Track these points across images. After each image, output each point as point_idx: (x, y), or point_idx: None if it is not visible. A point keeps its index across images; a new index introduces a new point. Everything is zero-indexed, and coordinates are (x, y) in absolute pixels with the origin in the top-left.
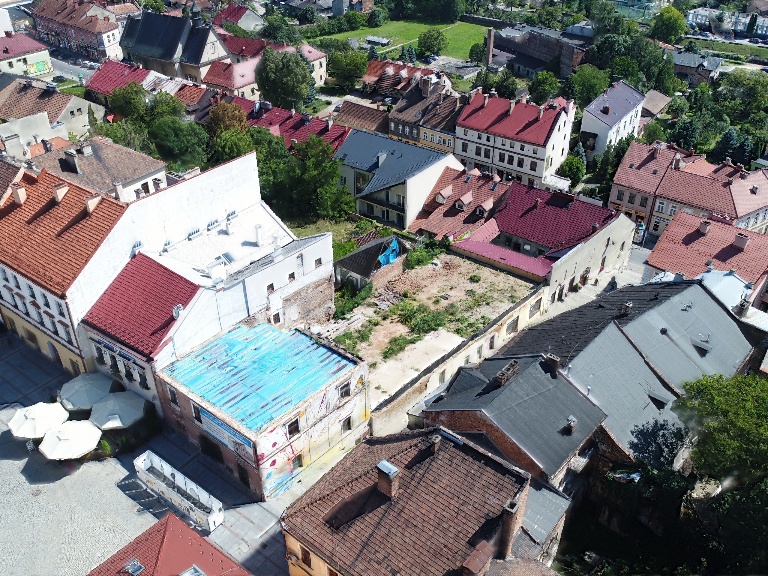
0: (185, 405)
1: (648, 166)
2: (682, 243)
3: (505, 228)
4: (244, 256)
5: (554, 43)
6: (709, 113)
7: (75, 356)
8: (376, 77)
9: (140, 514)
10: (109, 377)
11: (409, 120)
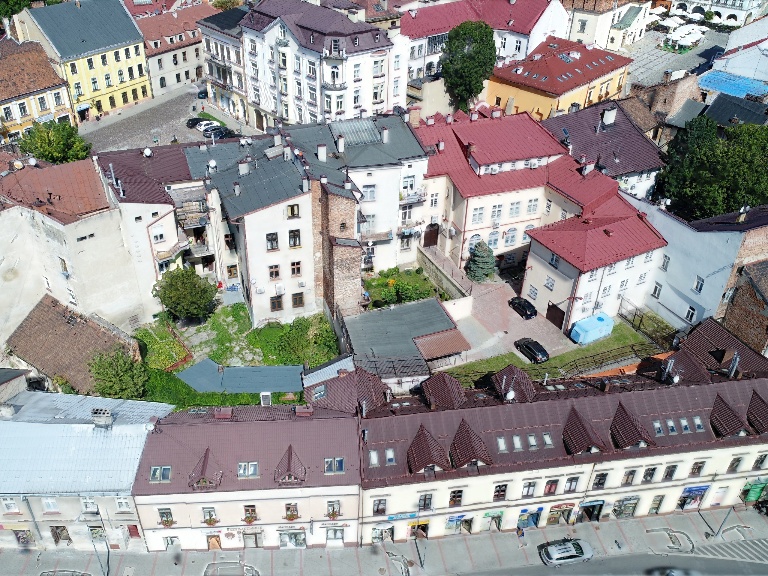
0: None
1: None
2: None
3: None
4: None
5: None
6: None
7: None
8: None
9: None
10: None
11: None
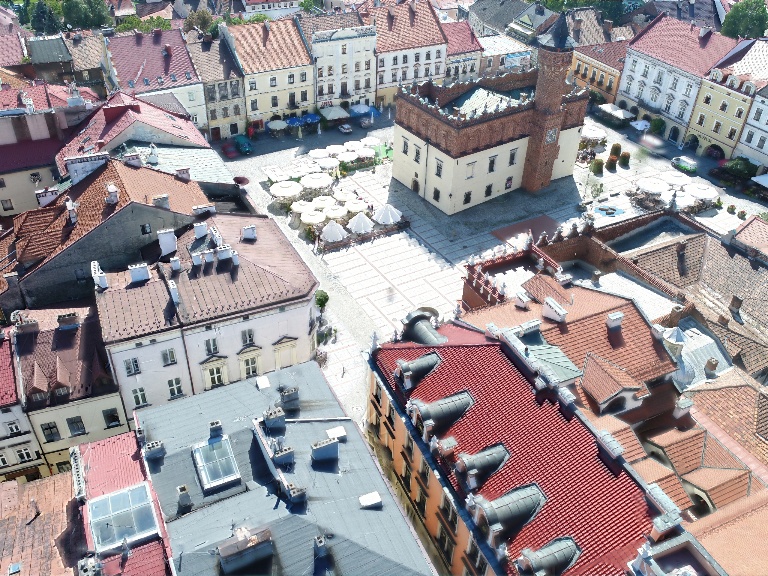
0: None
1: None
2: None
3: None
4: None
5: None
6: None
7: None
8: None
9: None
10: None
11: None
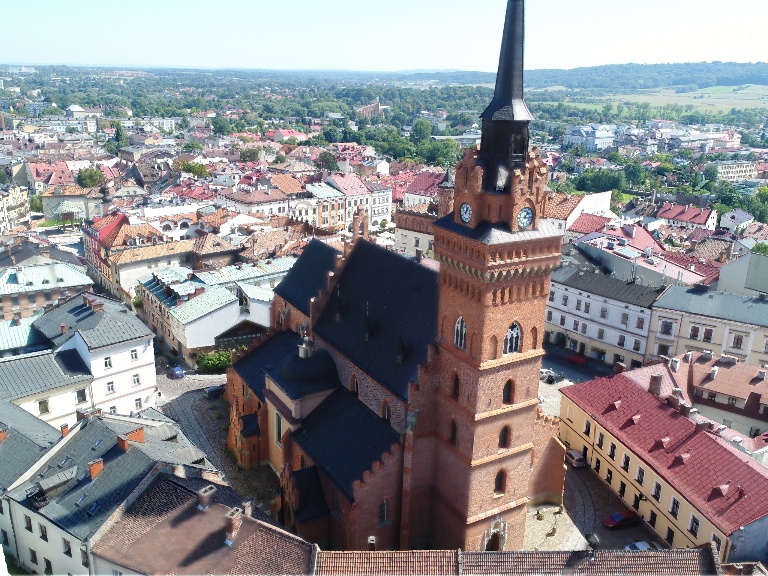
0: None
1: (759, 233)
2: None
3: None
4: None
5: (694, 199)
6: None
7: None
8: None
9: None
10: None
11: None
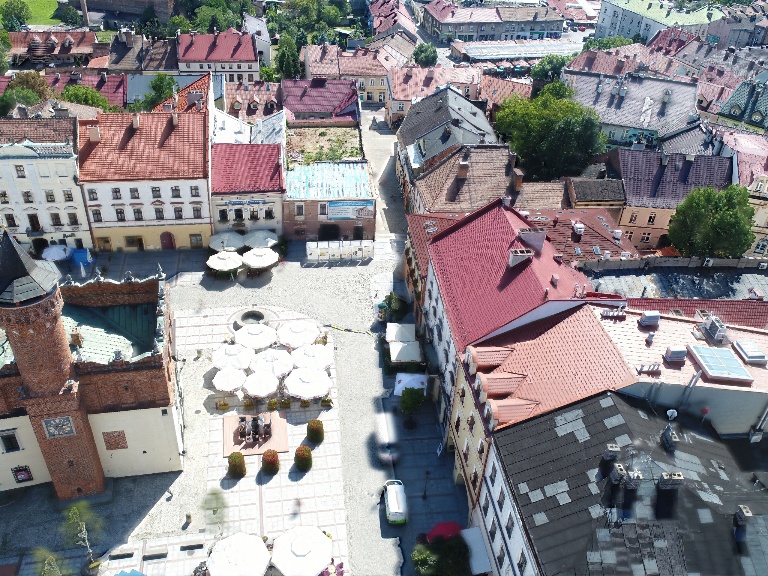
0: (311, 211)
1: (326, 58)
2: (404, 84)
3: (295, 110)
4: (243, 140)
5: None
6: (296, 28)
7: (200, 228)
8: (24, 48)
9: (333, 269)
10: (230, 231)
11: (130, 68)
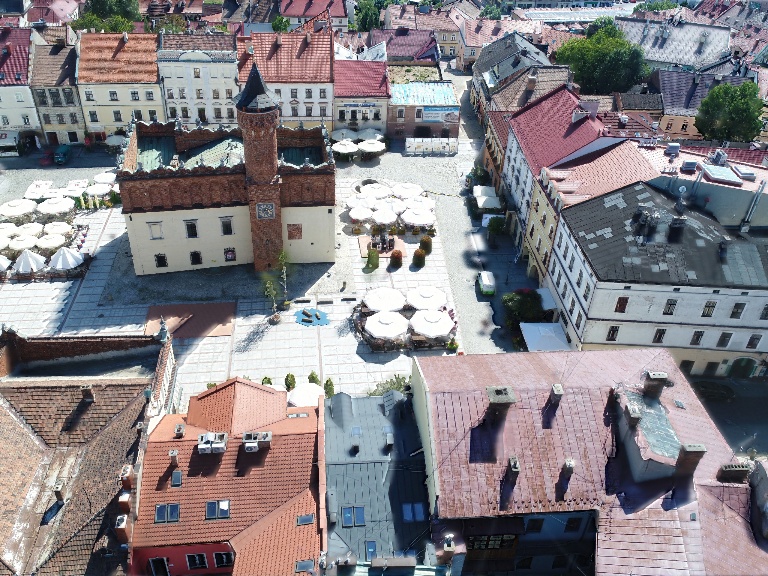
0: (410, 114)
1: (405, 16)
2: (476, 33)
3: None
4: None
5: None
6: None
7: None
8: (145, 8)
9: (426, 158)
10: None
11: None
